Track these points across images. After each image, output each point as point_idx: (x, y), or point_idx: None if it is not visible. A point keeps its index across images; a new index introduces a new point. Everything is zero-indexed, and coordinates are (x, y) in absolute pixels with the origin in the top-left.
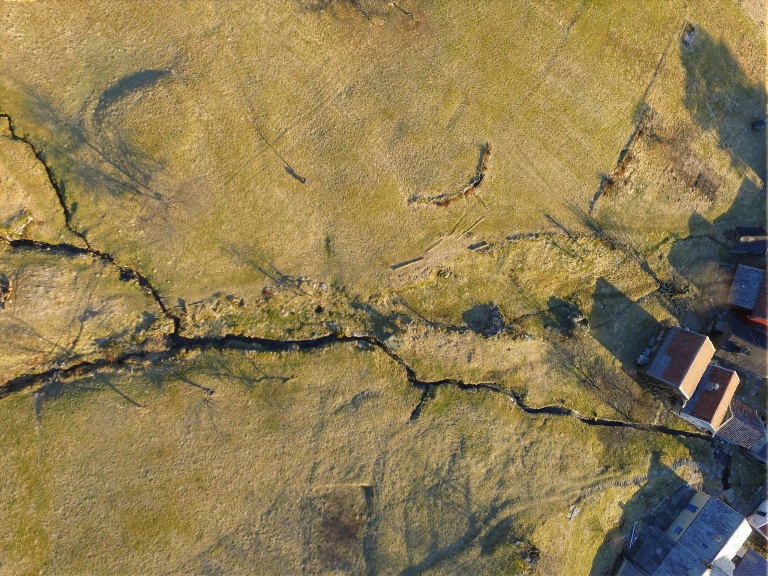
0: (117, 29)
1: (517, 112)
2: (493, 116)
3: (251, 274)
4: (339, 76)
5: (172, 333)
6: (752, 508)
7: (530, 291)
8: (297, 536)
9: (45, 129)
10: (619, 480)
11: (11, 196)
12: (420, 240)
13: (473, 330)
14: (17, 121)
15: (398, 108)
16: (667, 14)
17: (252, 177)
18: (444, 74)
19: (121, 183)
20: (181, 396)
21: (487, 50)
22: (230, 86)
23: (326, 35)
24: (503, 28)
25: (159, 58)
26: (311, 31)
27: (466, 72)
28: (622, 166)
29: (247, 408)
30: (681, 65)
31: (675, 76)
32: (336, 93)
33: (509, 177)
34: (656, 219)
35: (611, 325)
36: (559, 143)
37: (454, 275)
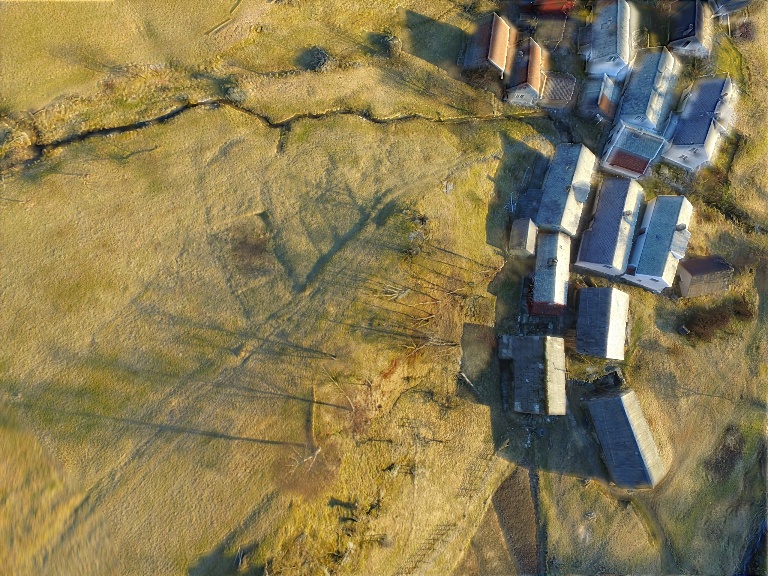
0: None
1: None
2: None
3: (80, 73)
4: None
5: (30, 145)
6: (599, 154)
7: (340, 29)
8: (214, 264)
9: None
10: (478, 157)
11: None
12: (221, 5)
13: (302, 70)
14: None
15: None
16: None
17: None
18: None
19: None
20: (59, 186)
21: None
22: None
23: None
24: None
25: None
26: None
27: None
28: None
29: (125, 181)
30: None
31: None
32: None
33: None
34: None
35: (423, 41)
36: None
37: (265, 29)
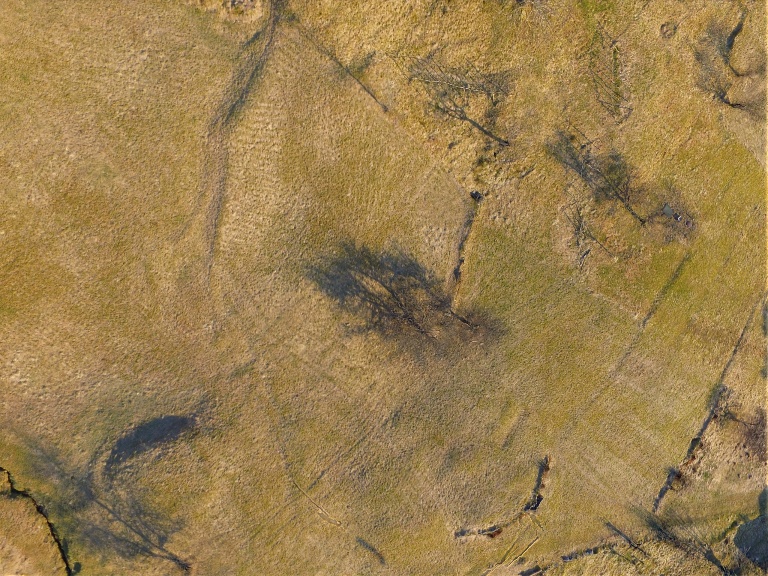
0: (136, 371)
1: (581, 417)
2: (555, 425)
3: None
4: (385, 400)
5: None
6: None
7: None
8: None
9: (49, 484)
10: None
11: (6, 566)
12: (466, 573)
13: None
14: (17, 477)
15: (450, 431)
16: (752, 284)
17: (281, 528)
18: (503, 386)
19: (132, 543)
20: None
21: (552, 354)
22: (262, 431)
23: (373, 356)
24: (572, 329)
25: (182, 402)
26: (357, 355)
27: (528, 381)
28: (692, 455)
29: None
30: (763, 335)
31: (756, 349)
32: (381, 422)
33: (568, 488)
34: (724, 502)
35: None
36: (625, 443)
37: None
